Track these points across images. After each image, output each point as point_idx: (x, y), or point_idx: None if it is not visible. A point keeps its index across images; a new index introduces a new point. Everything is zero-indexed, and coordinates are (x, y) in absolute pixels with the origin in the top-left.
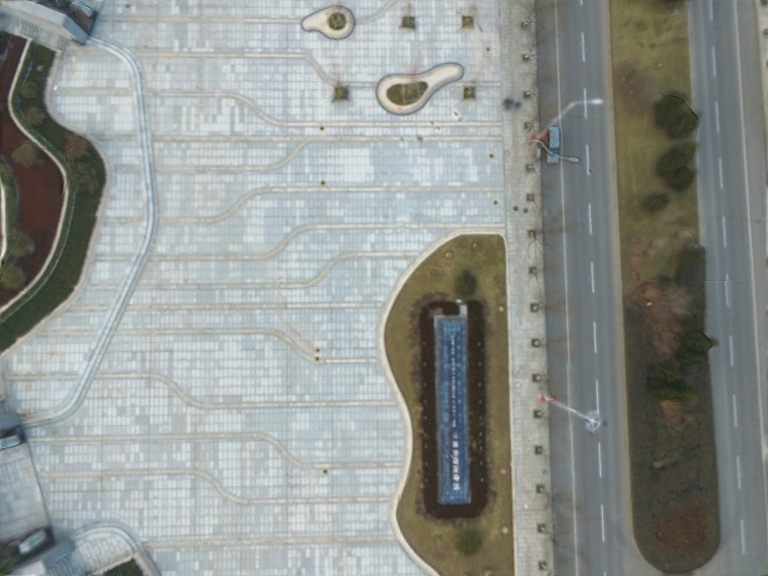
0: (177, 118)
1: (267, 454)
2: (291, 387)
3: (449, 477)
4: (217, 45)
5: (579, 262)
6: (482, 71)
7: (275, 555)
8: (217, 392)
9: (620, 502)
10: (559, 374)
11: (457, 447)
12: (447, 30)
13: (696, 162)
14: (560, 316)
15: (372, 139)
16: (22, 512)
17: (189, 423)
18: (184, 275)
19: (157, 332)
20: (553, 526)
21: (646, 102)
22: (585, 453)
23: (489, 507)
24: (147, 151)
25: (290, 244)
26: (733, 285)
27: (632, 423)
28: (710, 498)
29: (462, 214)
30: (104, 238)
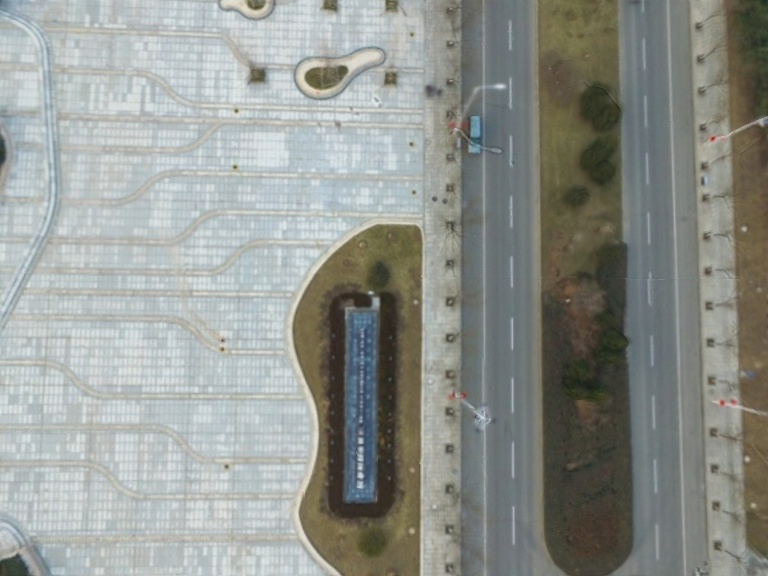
0: (85, 96)
1: (166, 447)
2: (194, 378)
3: (354, 475)
4: (130, 21)
5: (498, 256)
6: (405, 57)
7: (171, 553)
8: (116, 381)
9: (532, 504)
10: (473, 371)
11: (362, 444)
12: (370, 13)
13: (621, 156)
14: (477, 311)
15: (288, 123)
16: None
17: (85, 413)
18: (85, 259)
19: (54, 317)
20: (462, 528)
21: (571, 93)
22: (498, 453)
23: (396, 507)
24: (51, 129)
25: (198, 229)
26: (656, 283)
27: (547, 423)
28: (624, 502)
29: (379, 203)
30: (2, 218)
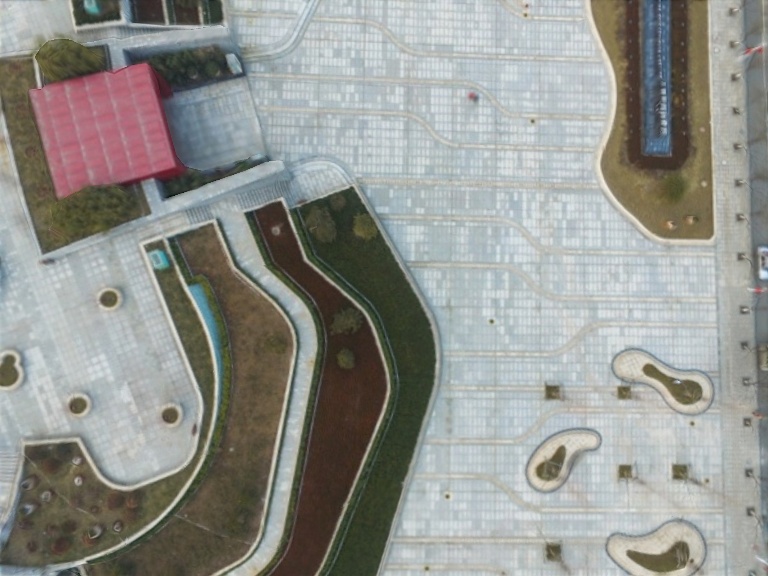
0: None
1: (477, 102)
2: (500, 40)
3: (654, 127)
4: None
5: None
6: None
7: (484, 197)
8: (429, 41)
9: None
10: (756, 42)
11: (665, 94)
12: None
13: None
14: None
15: None
16: (241, 142)
17: (402, 68)
18: None
19: None
20: (751, 181)
21: None
22: None
23: (689, 161)
24: None
25: None
26: None
27: None
28: None
29: None
30: None
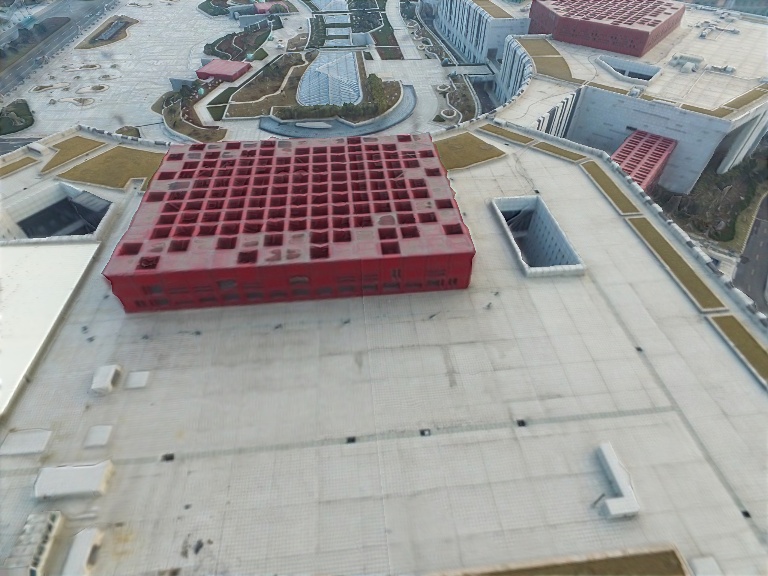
0: None
1: None
2: None
3: None
4: None
5: None
6: None
7: None
8: None
9: None
10: None
11: None
12: (62, 77)
13: None
14: None
15: None
16: None
17: None
18: None
19: None
20: None
21: None
22: None
23: None
24: None
25: None
26: None
27: None
28: None
29: None
30: None
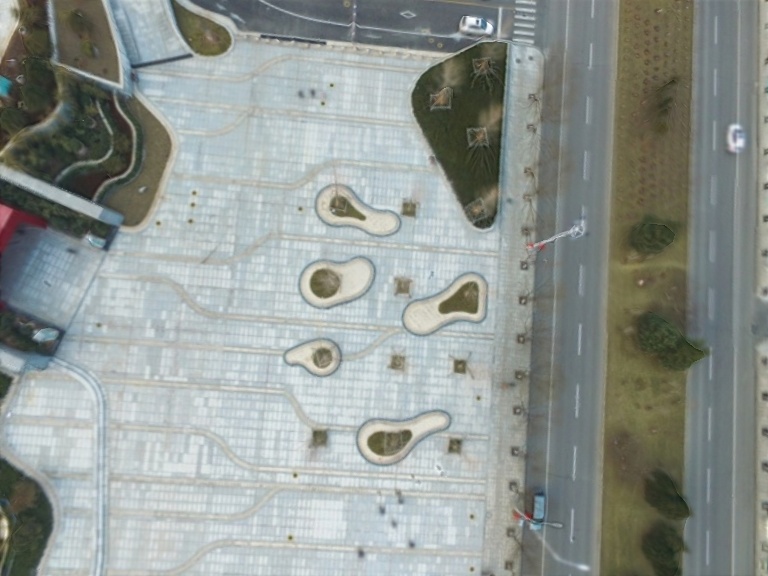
0: (139, 455)
1: None
2: None
3: None
4: (191, 374)
5: None
6: (470, 422)
7: None
8: None
9: None
10: None
11: None
12: (437, 374)
13: (683, 540)
14: None
15: (347, 491)
16: None
17: None
18: None
19: None
20: None
21: (637, 474)
22: None
23: None
24: (102, 491)
25: None
26: None
27: None
28: None
29: None
30: None
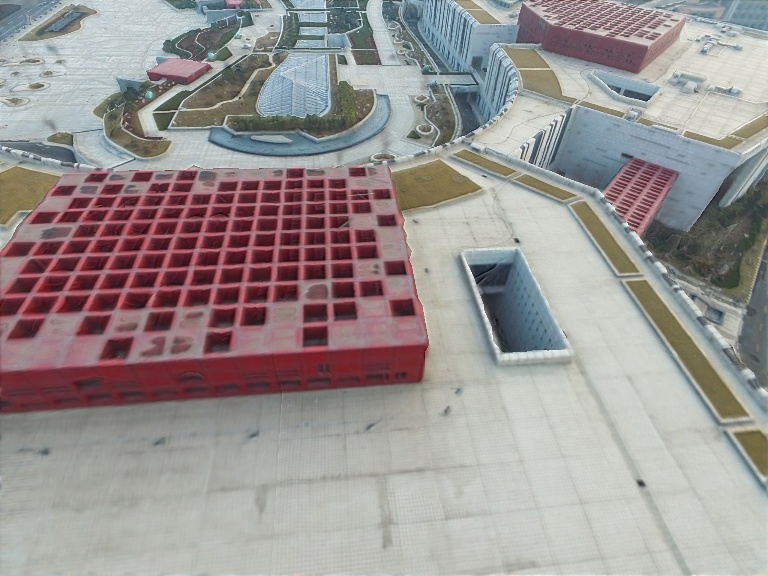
0: None
1: None
2: None
3: None
4: None
5: None
6: None
7: None
8: None
9: None
10: None
11: None
12: None
13: None
14: None
15: None
16: None
17: None
18: None
19: None
20: None
21: None
22: None
23: None
24: None
25: None
26: None
27: (2, 18)
28: None
29: None
30: None
